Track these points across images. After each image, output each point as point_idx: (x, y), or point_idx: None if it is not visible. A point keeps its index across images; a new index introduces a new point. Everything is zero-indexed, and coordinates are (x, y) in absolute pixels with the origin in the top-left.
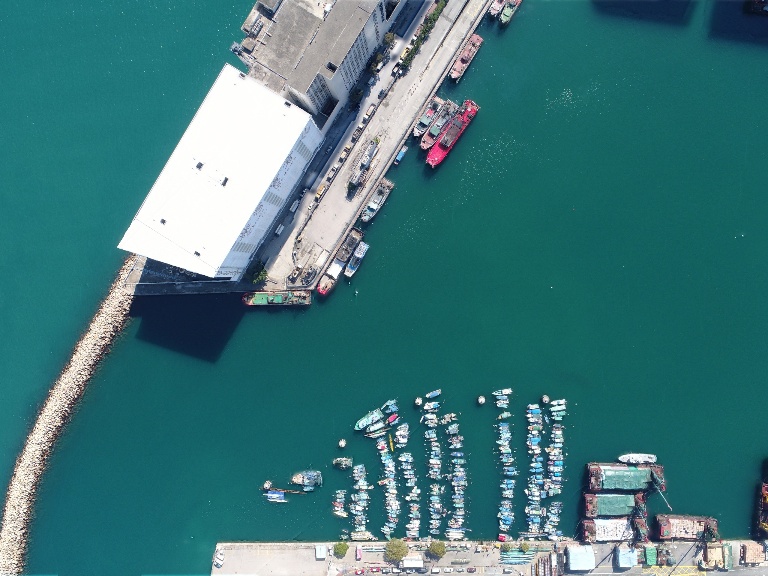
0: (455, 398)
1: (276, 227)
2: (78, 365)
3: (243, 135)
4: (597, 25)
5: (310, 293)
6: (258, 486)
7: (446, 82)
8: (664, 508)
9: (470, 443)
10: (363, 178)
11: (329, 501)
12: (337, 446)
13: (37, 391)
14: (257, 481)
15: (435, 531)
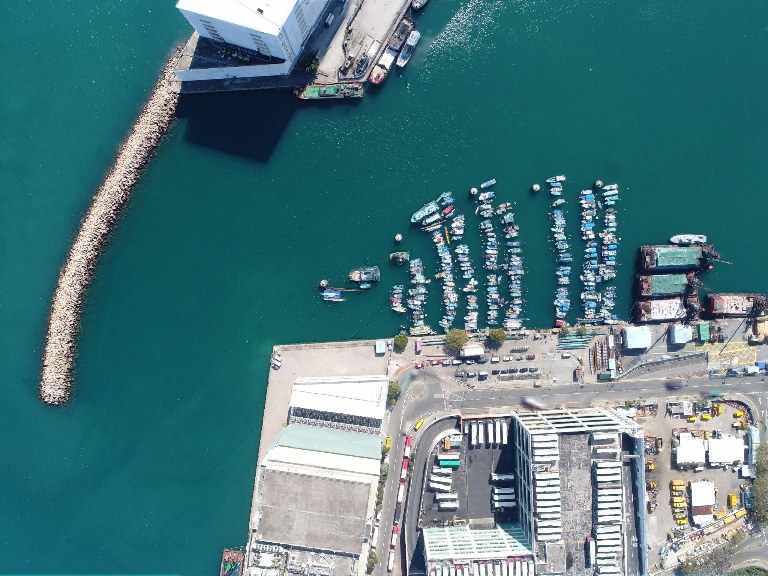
0: (509, 188)
1: (326, 17)
2: (123, 167)
3: None
4: None
5: (362, 86)
6: (314, 286)
7: None
8: (714, 287)
9: (525, 232)
10: None
11: (386, 298)
12: (393, 241)
13: (79, 199)
14: (312, 281)
15: (493, 322)
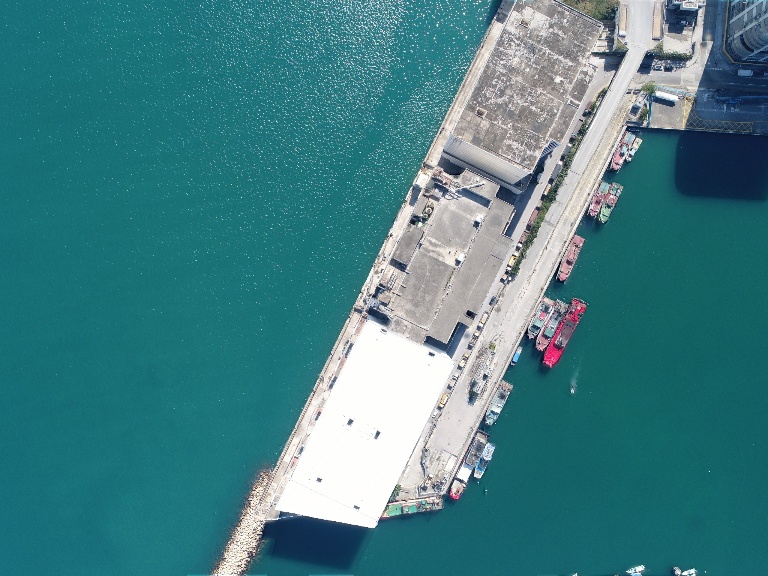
0: None
1: None
2: None
3: (391, 389)
4: (689, 215)
5: (442, 497)
6: None
7: (553, 282)
8: None
9: None
10: (486, 387)
11: None
12: None
13: None
14: None
15: None
